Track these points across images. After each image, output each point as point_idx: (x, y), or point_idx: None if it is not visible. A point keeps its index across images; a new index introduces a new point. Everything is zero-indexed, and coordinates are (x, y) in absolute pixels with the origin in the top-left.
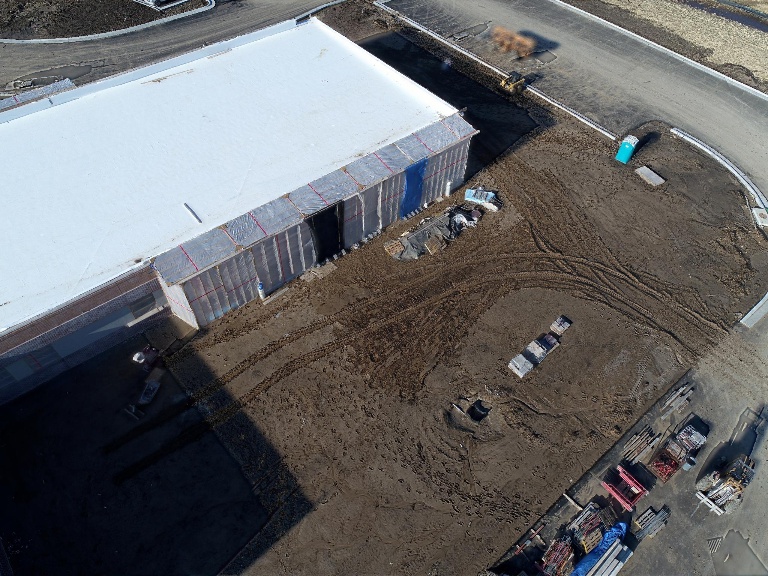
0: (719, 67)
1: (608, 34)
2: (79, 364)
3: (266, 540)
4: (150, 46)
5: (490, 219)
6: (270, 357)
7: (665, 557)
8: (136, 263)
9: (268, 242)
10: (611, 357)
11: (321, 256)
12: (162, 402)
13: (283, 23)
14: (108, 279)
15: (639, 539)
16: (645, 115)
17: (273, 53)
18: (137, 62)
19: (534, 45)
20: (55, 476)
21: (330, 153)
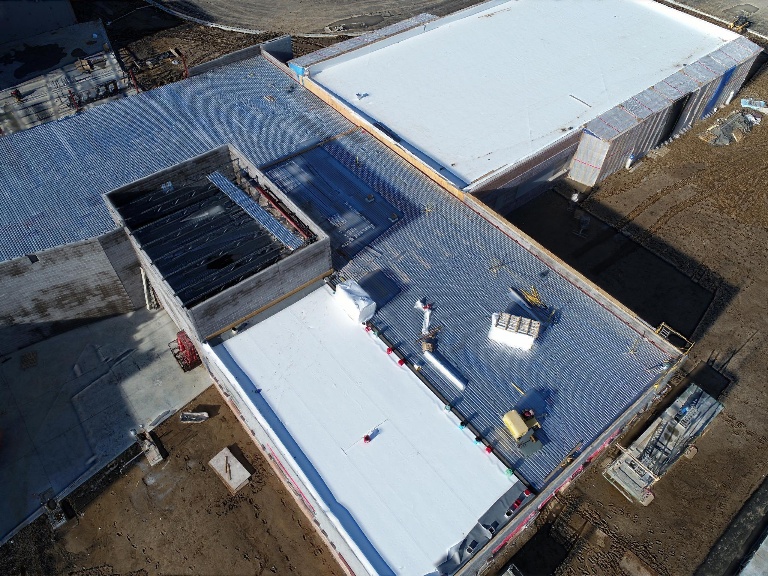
0: None
1: None
2: (519, 207)
3: (719, 306)
4: (418, 1)
5: None
6: (656, 204)
7: None
8: (564, 131)
9: (652, 118)
10: None
11: None
12: (595, 229)
13: None
14: (560, 137)
15: None
16: None
17: None
18: (416, 13)
19: None
20: None
21: (655, 64)
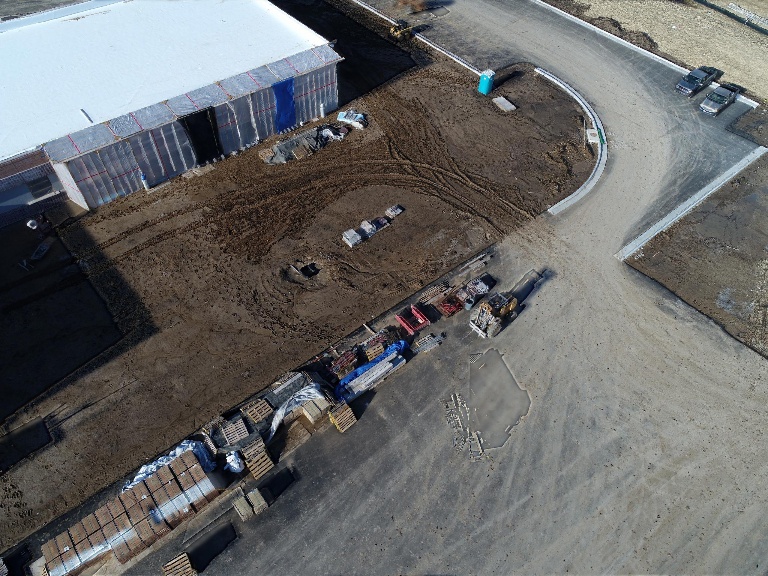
0: (592, 20)
1: None
2: None
3: (117, 351)
4: None
5: (355, 135)
6: (145, 230)
7: (433, 365)
8: None
9: (144, 136)
10: (431, 234)
11: (202, 159)
12: (50, 260)
13: None
14: (5, 158)
15: (415, 353)
16: (515, 58)
17: None
18: None
19: (432, 2)
20: None
21: (213, 74)
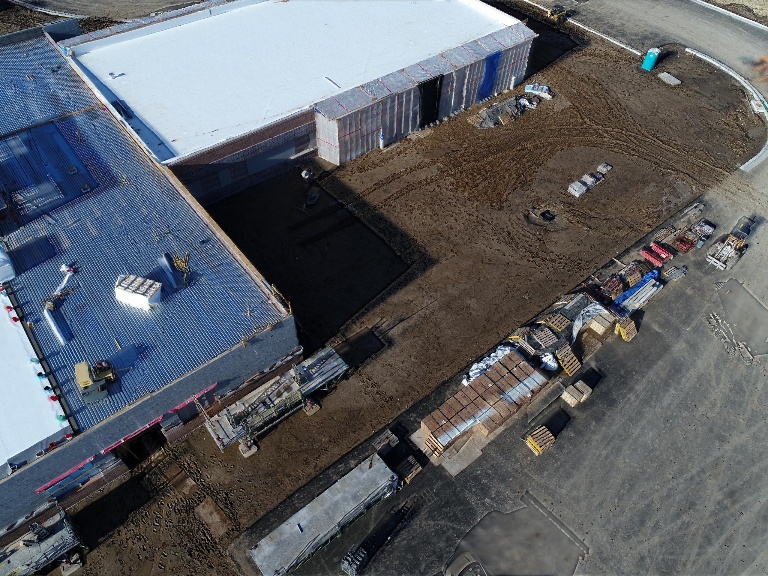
0: (725, 6)
1: None
2: (258, 183)
3: (410, 278)
4: None
5: (546, 104)
6: (394, 182)
7: (685, 291)
8: None
9: (392, 99)
10: (643, 187)
11: (422, 123)
12: (322, 205)
13: None
14: (286, 115)
15: (667, 281)
16: (665, 39)
17: None
18: None
19: None
20: (258, 242)
21: (426, 49)
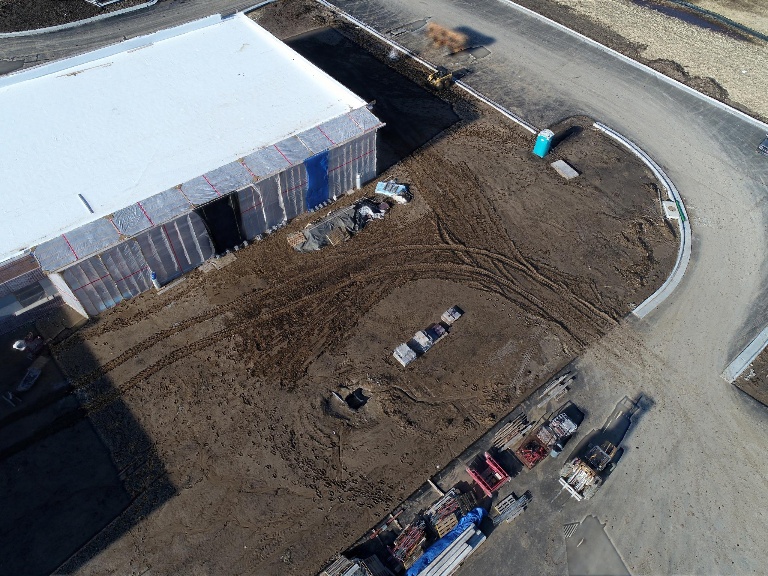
0: (651, 62)
1: (545, 30)
2: None
3: (124, 524)
4: (86, 41)
5: (398, 211)
6: (156, 346)
7: (519, 542)
8: None
9: (155, 232)
10: (498, 347)
11: (221, 247)
12: (42, 389)
13: (207, 18)
14: None
15: (495, 524)
16: (570, 110)
17: (194, 47)
18: None
19: (470, 41)
20: None
21: (234, 145)
